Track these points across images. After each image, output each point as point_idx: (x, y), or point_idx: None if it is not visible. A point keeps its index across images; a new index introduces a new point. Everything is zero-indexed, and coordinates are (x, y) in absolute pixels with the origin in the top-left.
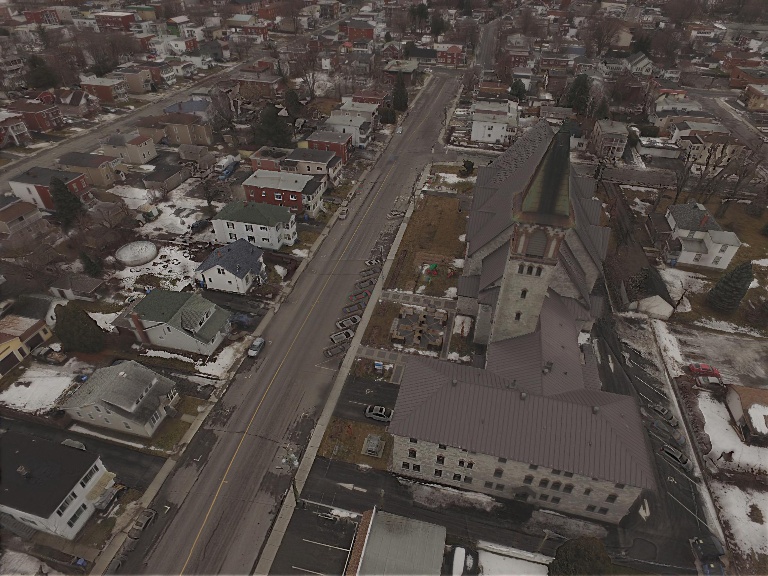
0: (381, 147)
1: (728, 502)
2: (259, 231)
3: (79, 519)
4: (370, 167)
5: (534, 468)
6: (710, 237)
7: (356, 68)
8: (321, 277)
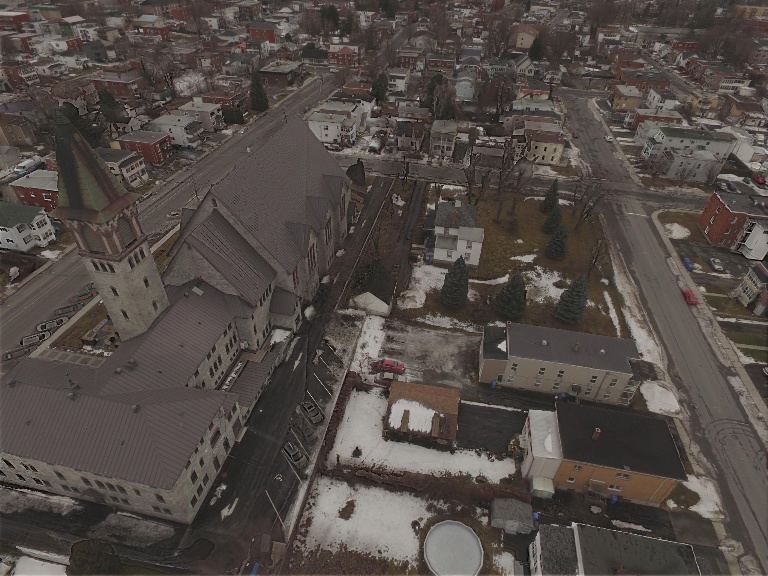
0: (213, 147)
1: (325, 499)
2: (1, 232)
3: None
4: (187, 167)
5: (79, 470)
6: None
7: (239, 69)
8: (55, 278)
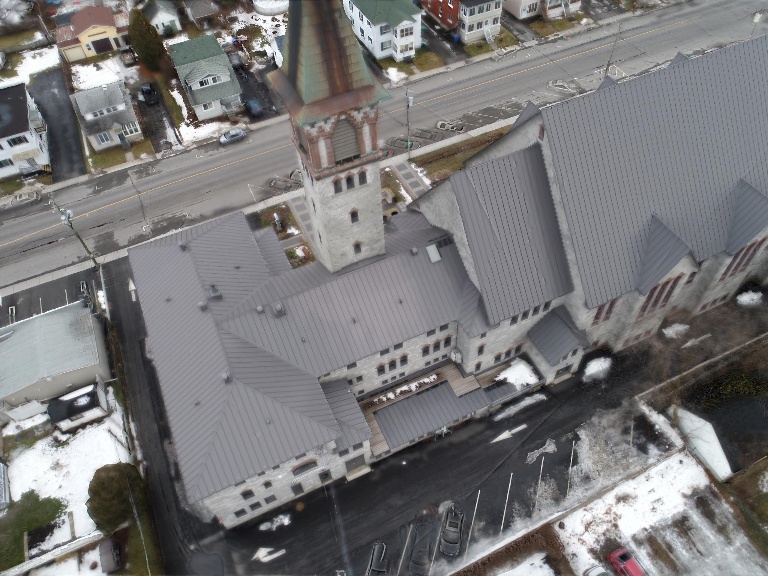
0: None
1: None
2: None
3: (6, 168)
4: (644, 10)
5: None
6: None
7: None
8: None
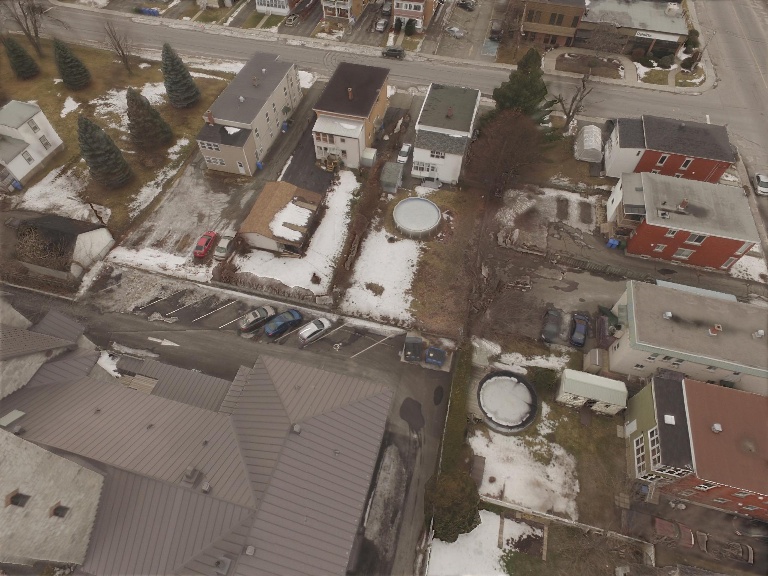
0: None
1: (363, 305)
2: None
3: None
4: None
5: None
6: (4, 126)
7: None
8: None
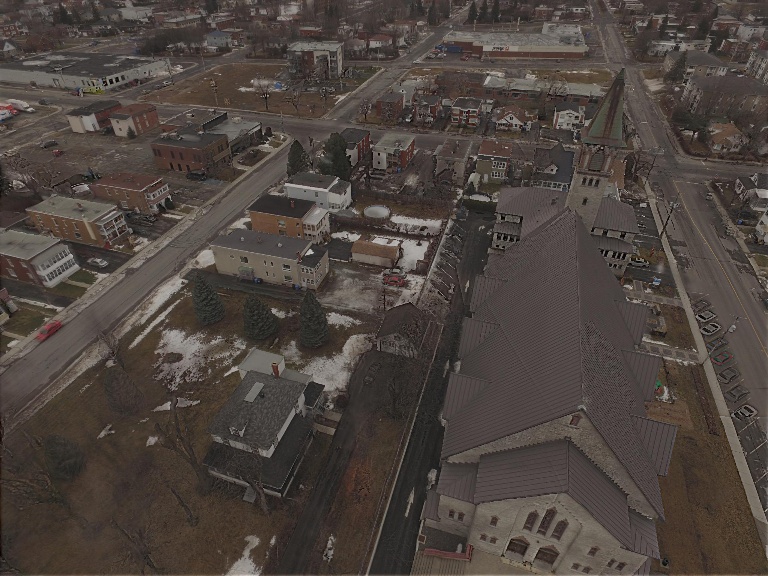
0: None
1: None
2: None
3: None
4: None
5: None
6: None
7: None
8: None
